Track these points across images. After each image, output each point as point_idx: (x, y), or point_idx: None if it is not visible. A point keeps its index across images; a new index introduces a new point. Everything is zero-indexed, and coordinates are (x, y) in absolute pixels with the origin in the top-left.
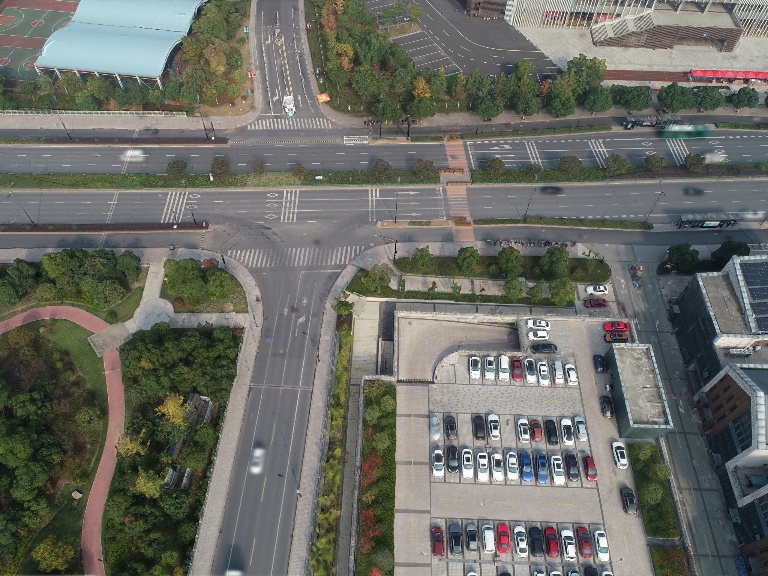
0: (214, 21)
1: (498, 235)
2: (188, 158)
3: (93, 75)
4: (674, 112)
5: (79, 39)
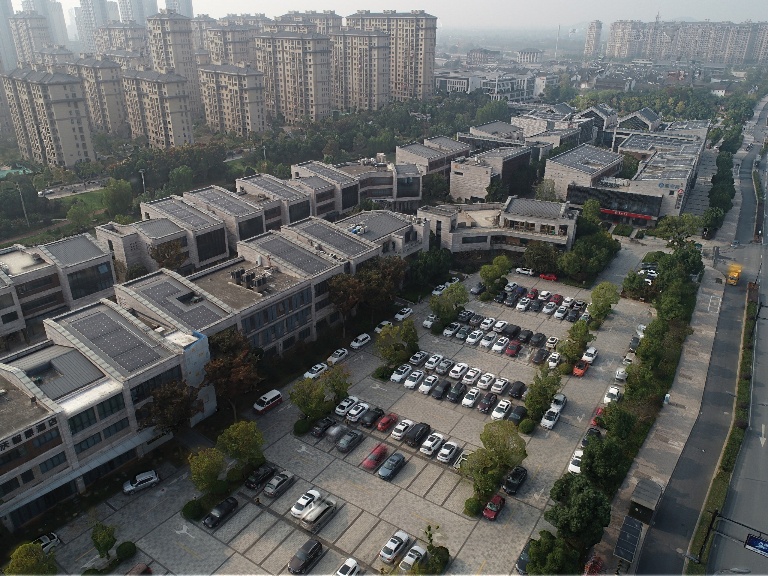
0: None
1: (757, 146)
2: None
3: None
4: None
5: None
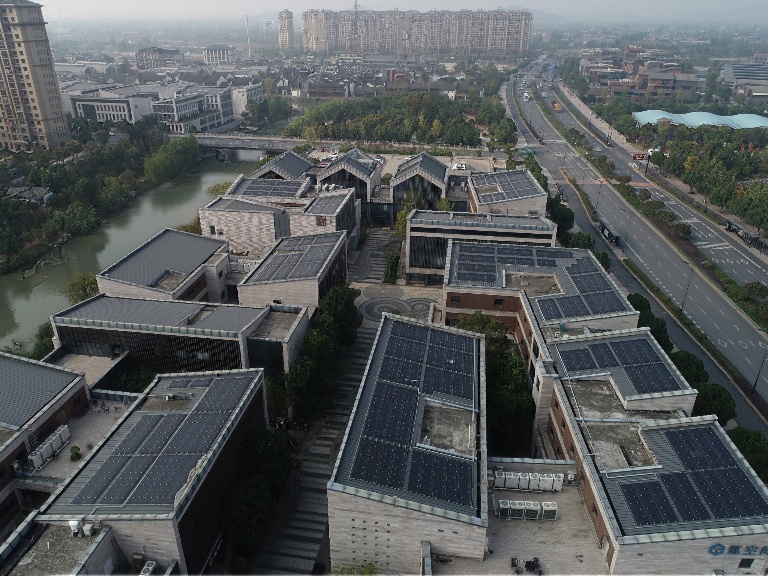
0: (711, 130)
1: (565, 188)
2: (591, 142)
3: (635, 120)
4: (764, 236)
5: (658, 113)
